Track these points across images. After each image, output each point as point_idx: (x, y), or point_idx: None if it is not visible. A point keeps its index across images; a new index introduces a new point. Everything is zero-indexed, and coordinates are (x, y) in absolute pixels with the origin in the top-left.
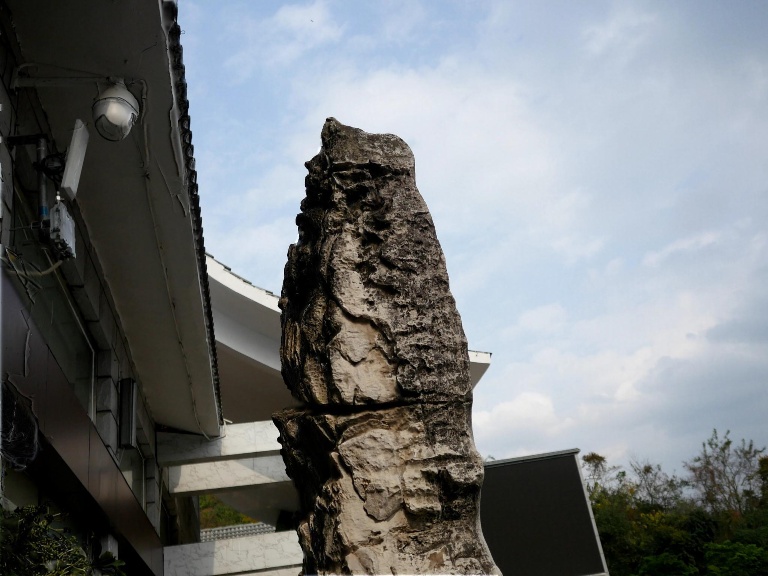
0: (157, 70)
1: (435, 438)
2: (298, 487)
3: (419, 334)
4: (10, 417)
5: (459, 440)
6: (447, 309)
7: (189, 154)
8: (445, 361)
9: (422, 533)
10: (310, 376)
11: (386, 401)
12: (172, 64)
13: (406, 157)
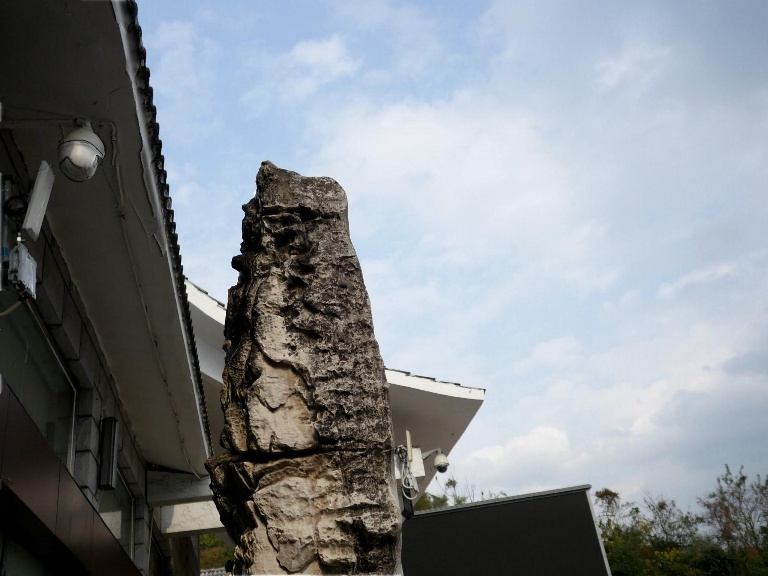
0: (125, 113)
1: (353, 486)
2: (229, 534)
3: (340, 380)
4: None
5: (378, 489)
6: (370, 354)
7: (165, 194)
8: (365, 407)
9: None
10: (231, 422)
11: (303, 448)
12: (141, 107)
13: (338, 200)
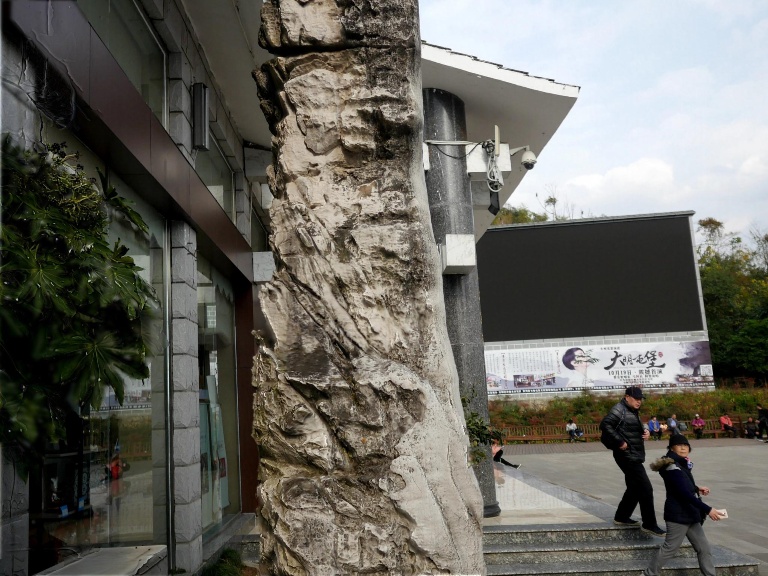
0: None
1: (376, 82)
2: None
3: None
4: (41, 74)
5: (400, 85)
6: None
7: None
8: (391, 5)
9: (358, 169)
10: (267, 19)
11: (331, 42)
12: None
13: None
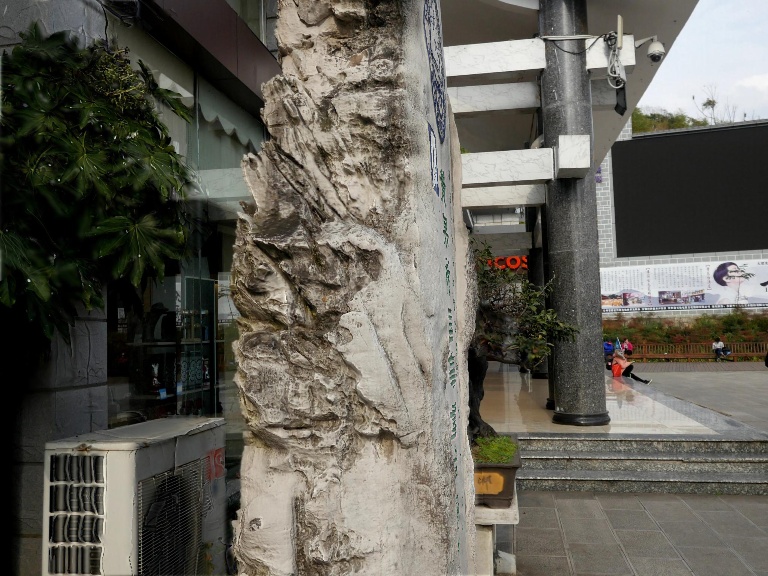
0: None
1: None
2: None
3: None
4: None
5: None
6: None
7: None
8: None
9: (351, 39)
10: None
11: None
12: None
13: None
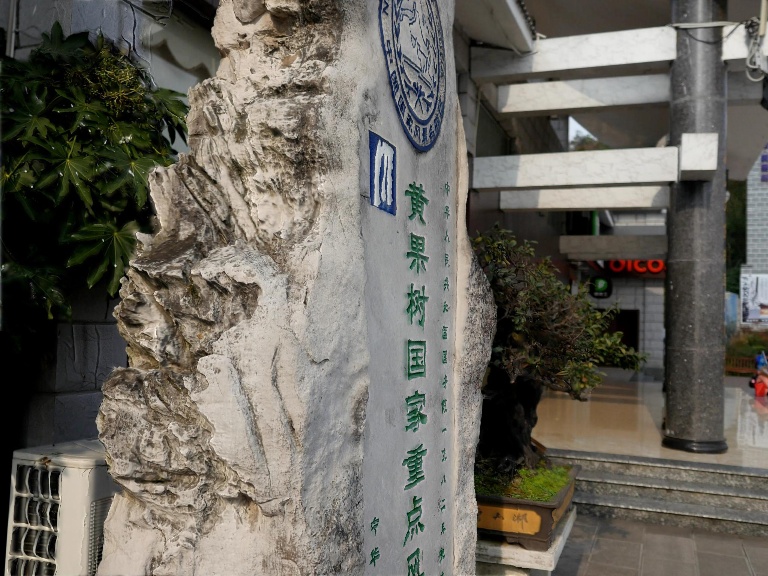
0: None
1: None
2: None
3: None
4: None
5: None
6: None
7: None
8: None
9: (288, 38)
10: None
11: None
12: None
13: None
